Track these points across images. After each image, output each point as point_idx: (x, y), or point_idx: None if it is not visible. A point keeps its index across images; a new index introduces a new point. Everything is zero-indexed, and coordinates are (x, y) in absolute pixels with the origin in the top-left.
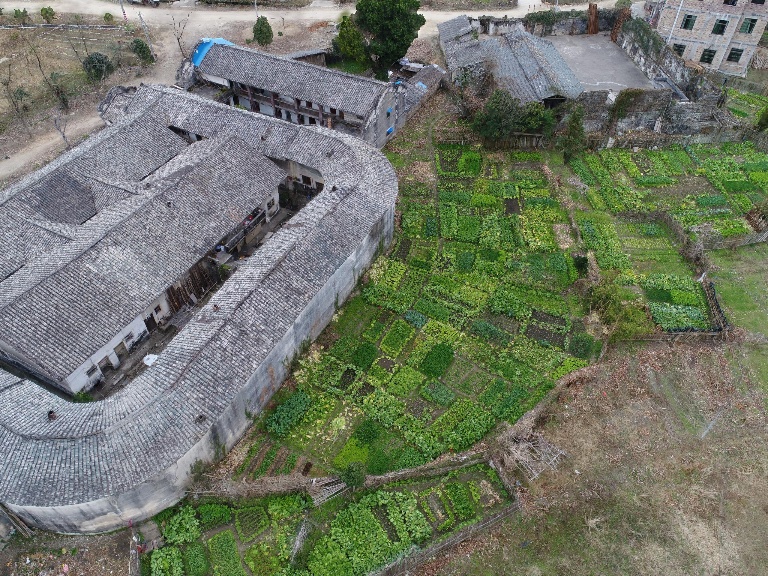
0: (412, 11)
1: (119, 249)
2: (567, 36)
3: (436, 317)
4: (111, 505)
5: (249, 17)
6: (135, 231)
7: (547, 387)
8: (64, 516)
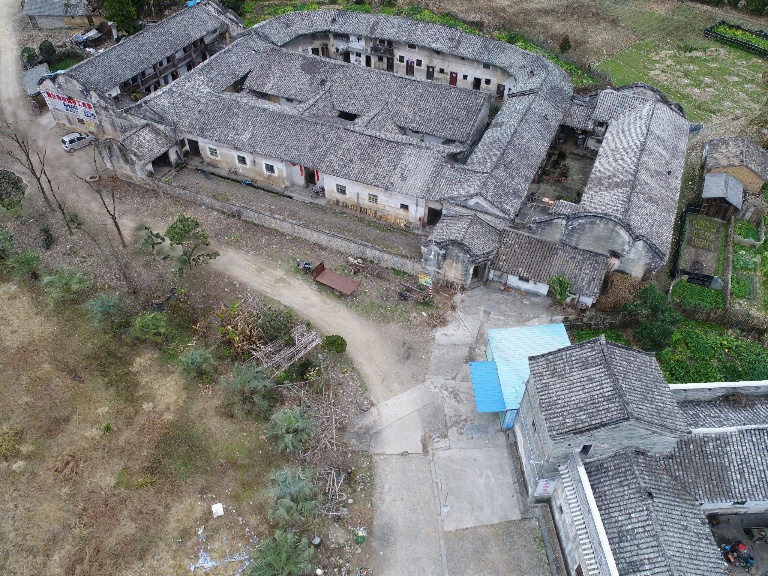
0: None
1: None
2: None
3: None
4: None
5: None
6: None
7: (443, 16)
8: None
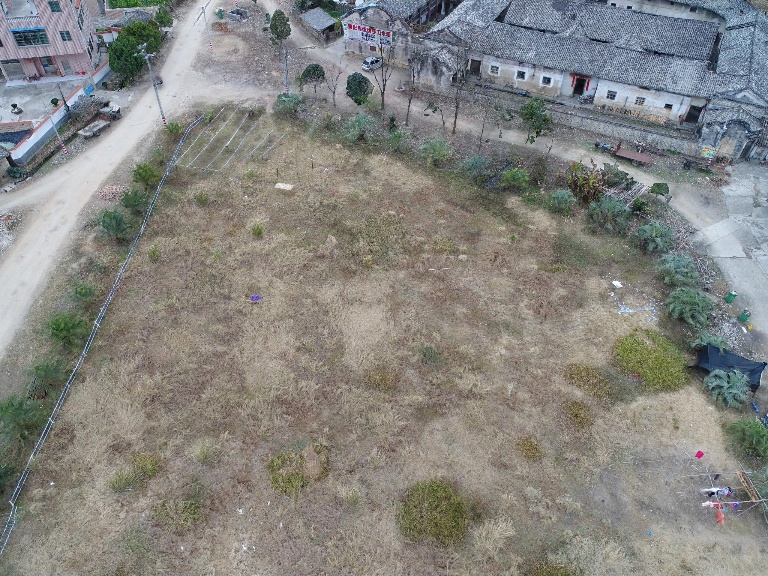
0: None
1: None
2: None
3: None
4: None
5: (184, 60)
6: None
7: None
8: None
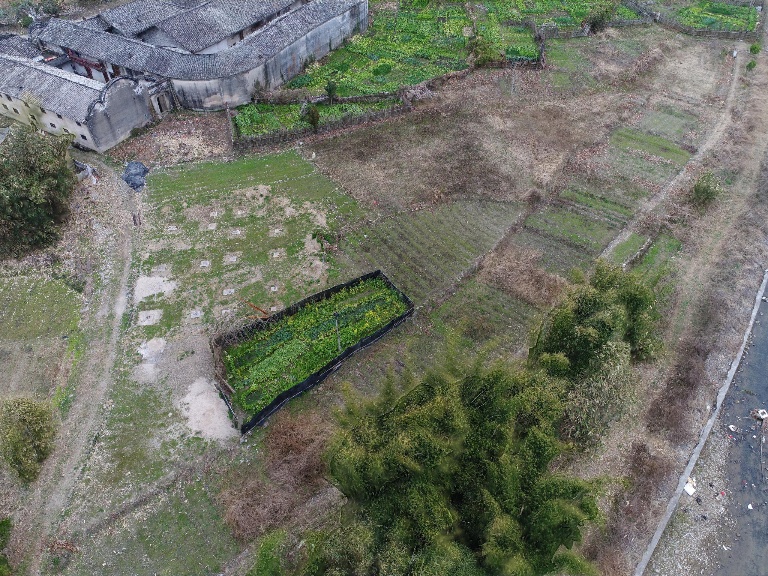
0: None
1: (217, 9)
2: None
3: (385, 57)
4: (219, 87)
5: None
6: (224, 3)
7: None
8: (198, 91)
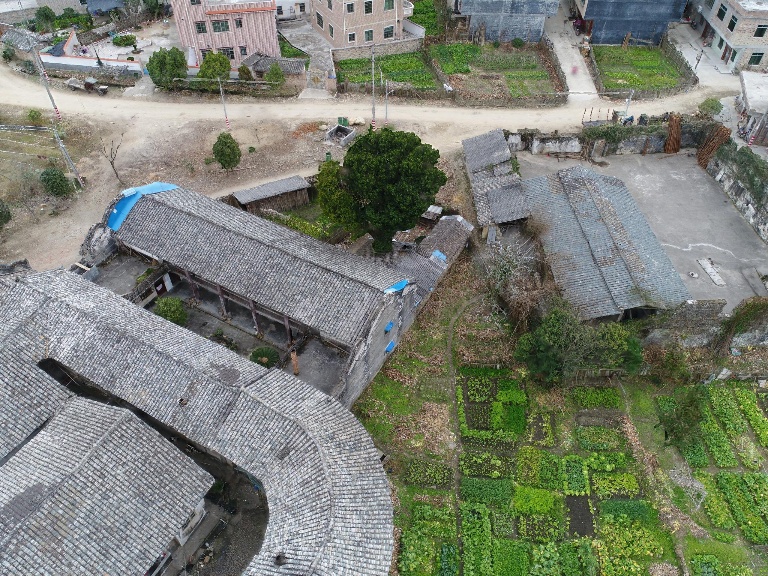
0: (427, 166)
1: None
2: (637, 156)
3: None
4: None
5: (218, 113)
6: None
7: None
8: None
